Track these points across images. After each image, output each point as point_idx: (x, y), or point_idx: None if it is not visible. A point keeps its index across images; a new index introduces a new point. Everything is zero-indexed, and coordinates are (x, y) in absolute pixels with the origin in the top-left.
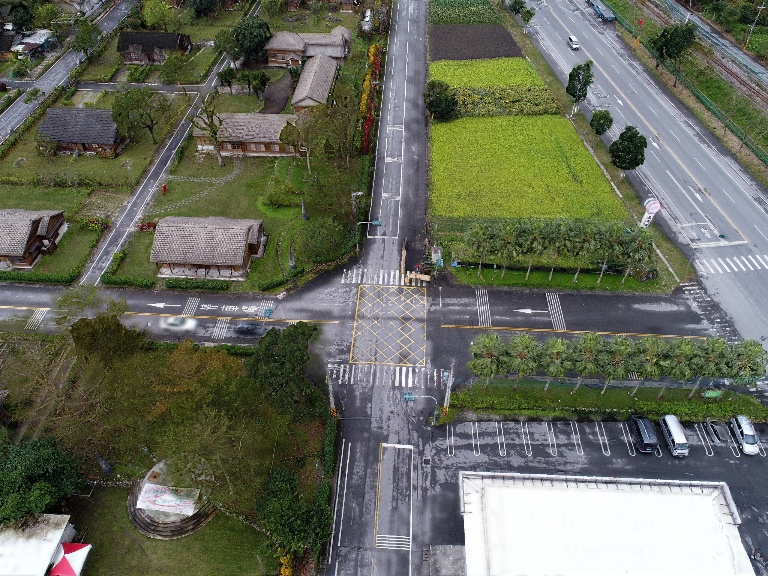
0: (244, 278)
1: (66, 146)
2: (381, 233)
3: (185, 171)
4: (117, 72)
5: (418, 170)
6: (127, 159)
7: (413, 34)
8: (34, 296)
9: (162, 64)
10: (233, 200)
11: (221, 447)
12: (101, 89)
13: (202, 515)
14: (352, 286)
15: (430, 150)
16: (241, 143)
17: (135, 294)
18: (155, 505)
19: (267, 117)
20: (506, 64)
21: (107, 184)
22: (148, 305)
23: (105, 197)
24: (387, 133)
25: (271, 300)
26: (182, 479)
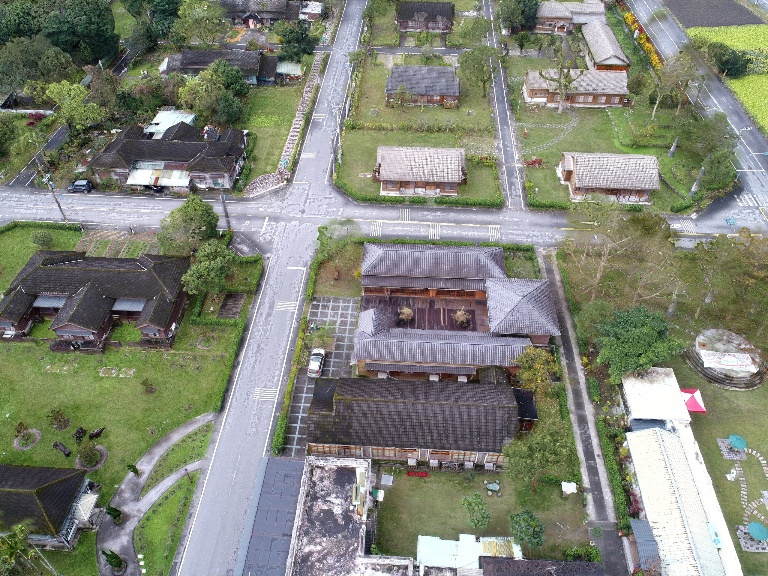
0: (650, 203)
1: (409, 98)
2: (747, 167)
3: (529, 119)
4: (400, 38)
5: (741, 117)
6: (469, 109)
7: (651, 5)
8: (478, 216)
9: (436, 31)
10: (591, 142)
11: (739, 325)
12: (397, 52)
13: (762, 373)
14: (753, 208)
15: (741, 101)
16: (573, 95)
17: (564, 215)
18: (721, 365)
19: (595, 71)
20: (758, 30)
21: (469, 129)
22: (583, 223)
23: (475, 140)
24: (691, 87)
25: (687, 219)
26: (727, 347)
